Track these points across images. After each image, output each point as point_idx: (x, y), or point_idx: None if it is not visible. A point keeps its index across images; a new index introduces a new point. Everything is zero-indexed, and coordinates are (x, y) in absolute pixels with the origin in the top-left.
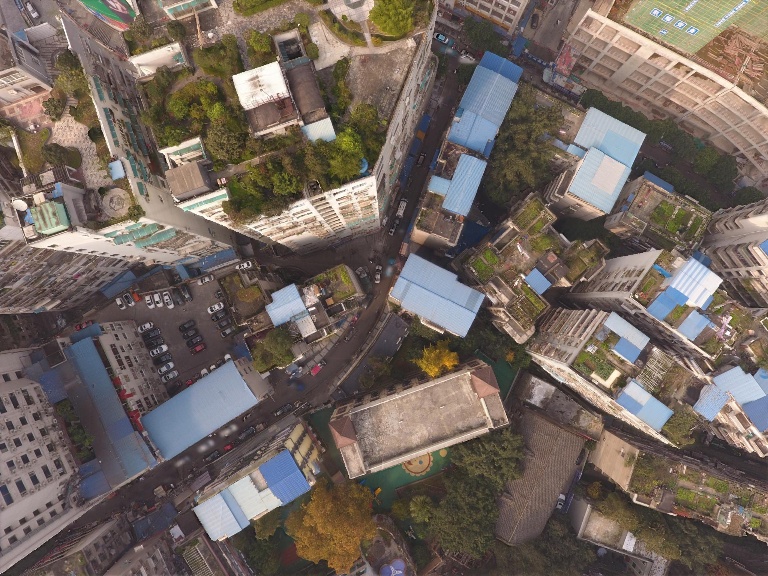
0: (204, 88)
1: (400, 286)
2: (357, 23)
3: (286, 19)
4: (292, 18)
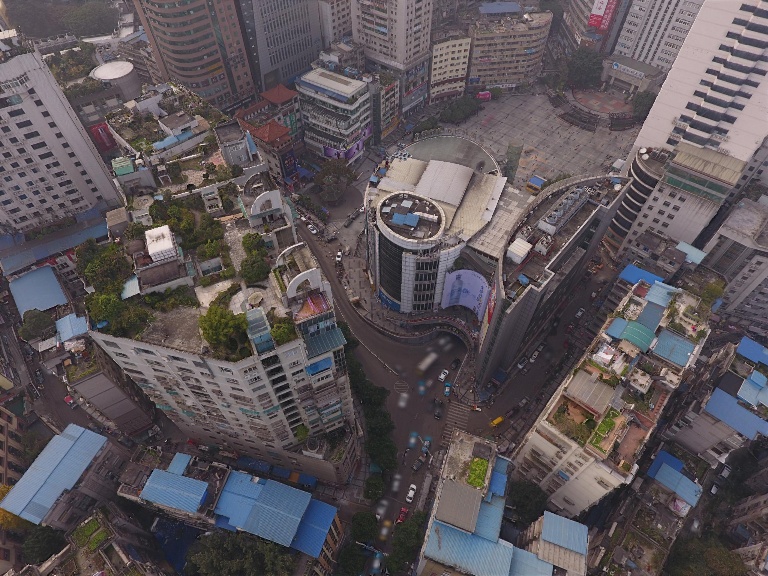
0: (185, 222)
1: (76, 431)
2: (227, 309)
3: (239, 265)
4: (239, 269)
